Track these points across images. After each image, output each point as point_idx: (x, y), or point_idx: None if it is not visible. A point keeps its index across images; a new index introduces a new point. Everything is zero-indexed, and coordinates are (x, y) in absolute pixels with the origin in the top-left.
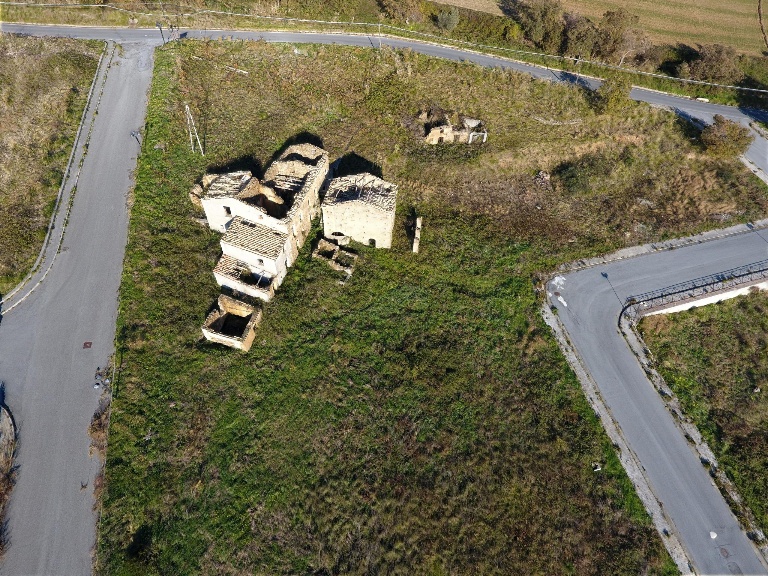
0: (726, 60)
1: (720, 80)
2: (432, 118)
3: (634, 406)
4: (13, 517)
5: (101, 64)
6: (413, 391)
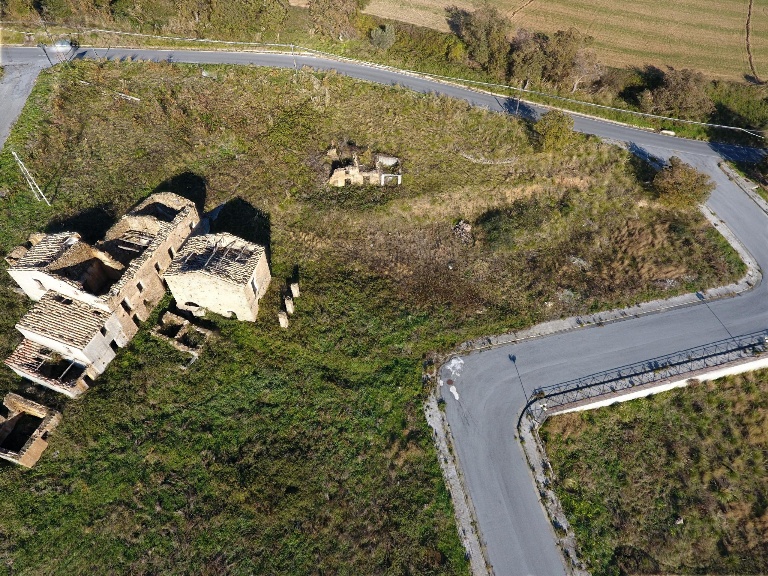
0: (693, 89)
1: (688, 111)
2: (340, 156)
3: (517, 543)
4: None
5: None
6: (236, 519)
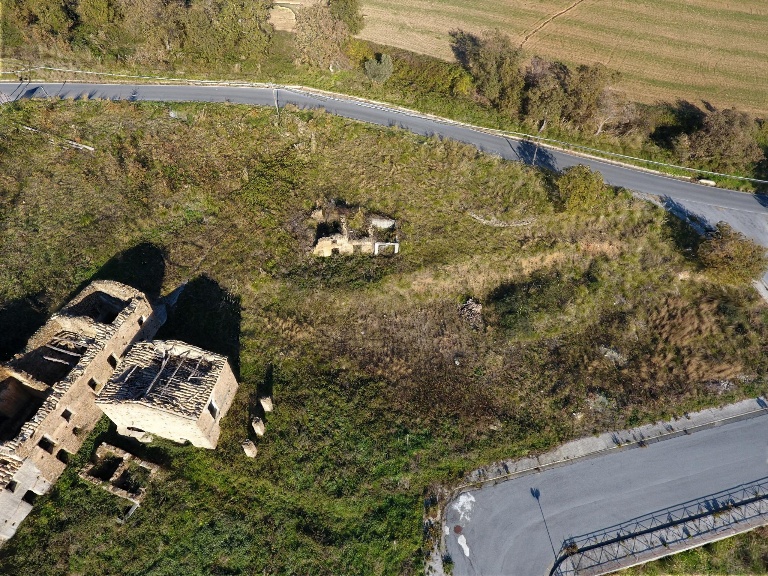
0: (739, 135)
1: (731, 158)
2: (327, 219)
3: None
4: None
5: None
6: None
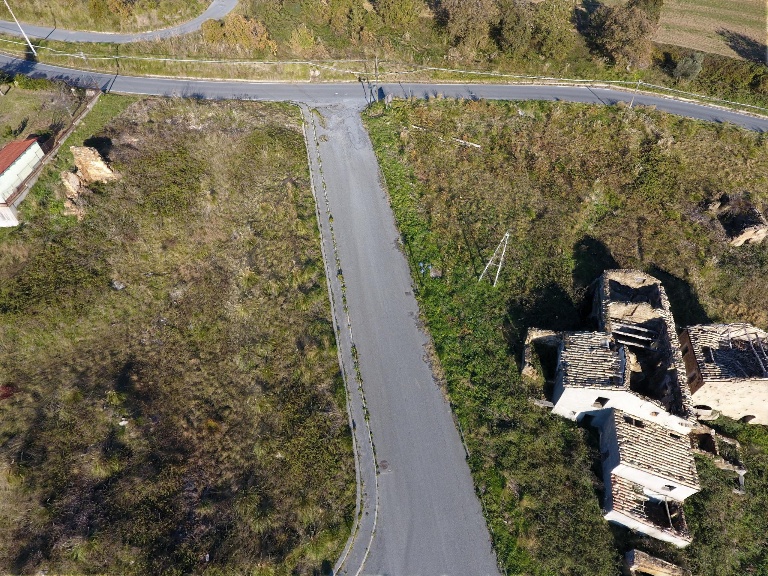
0: None
1: None
2: (730, 210)
3: None
4: None
5: (307, 140)
6: None
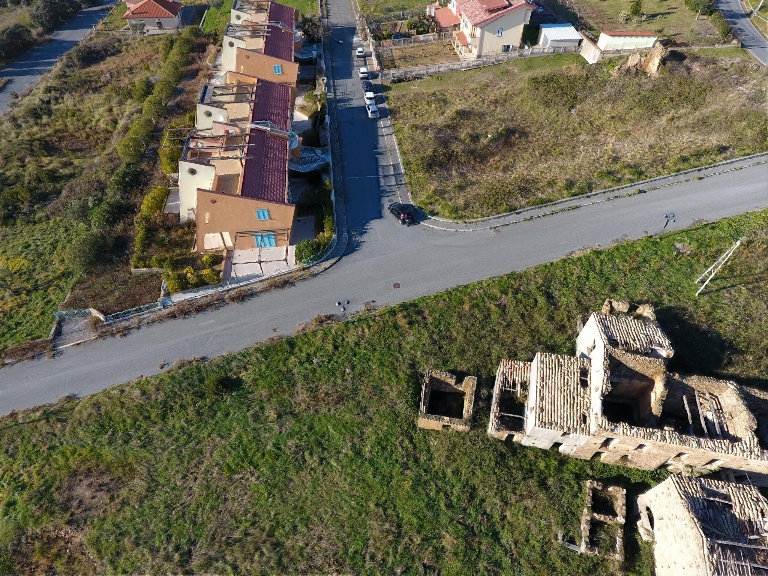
0: None
1: None
2: None
3: None
4: (260, 298)
5: None
6: None
